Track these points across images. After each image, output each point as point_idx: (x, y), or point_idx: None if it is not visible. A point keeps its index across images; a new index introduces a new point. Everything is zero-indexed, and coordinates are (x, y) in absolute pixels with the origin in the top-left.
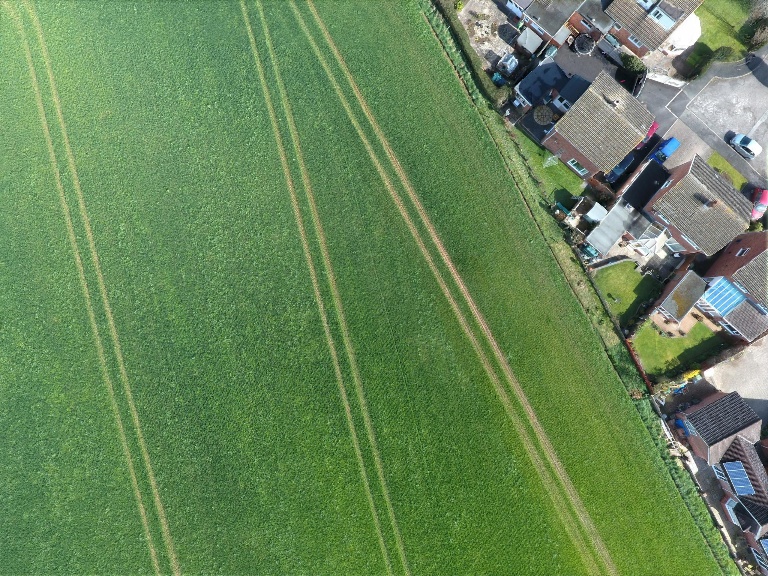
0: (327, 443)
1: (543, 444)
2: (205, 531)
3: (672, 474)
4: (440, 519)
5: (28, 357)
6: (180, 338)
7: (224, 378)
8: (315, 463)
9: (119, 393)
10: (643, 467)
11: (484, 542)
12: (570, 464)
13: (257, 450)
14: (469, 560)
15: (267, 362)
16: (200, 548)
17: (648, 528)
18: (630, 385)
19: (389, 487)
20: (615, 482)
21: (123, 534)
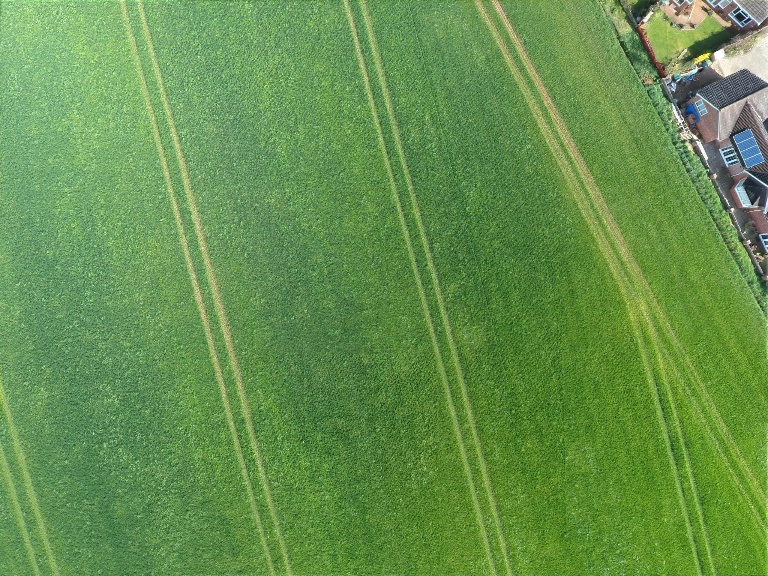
0: (346, 108)
1: (557, 124)
2: (226, 186)
3: (683, 159)
4: (456, 188)
5: (53, 9)
6: (202, 0)
7: (245, 41)
8: (334, 127)
9: (142, 49)
10: (654, 151)
11: (499, 212)
12: (583, 144)
13: (277, 111)
14: (484, 229)
15: (287, 28)
16: (221, 202)
17: (659, 210)
18: (642, 71)
19: (406, 154)
20: (627, 164)
21: (146, 184)
